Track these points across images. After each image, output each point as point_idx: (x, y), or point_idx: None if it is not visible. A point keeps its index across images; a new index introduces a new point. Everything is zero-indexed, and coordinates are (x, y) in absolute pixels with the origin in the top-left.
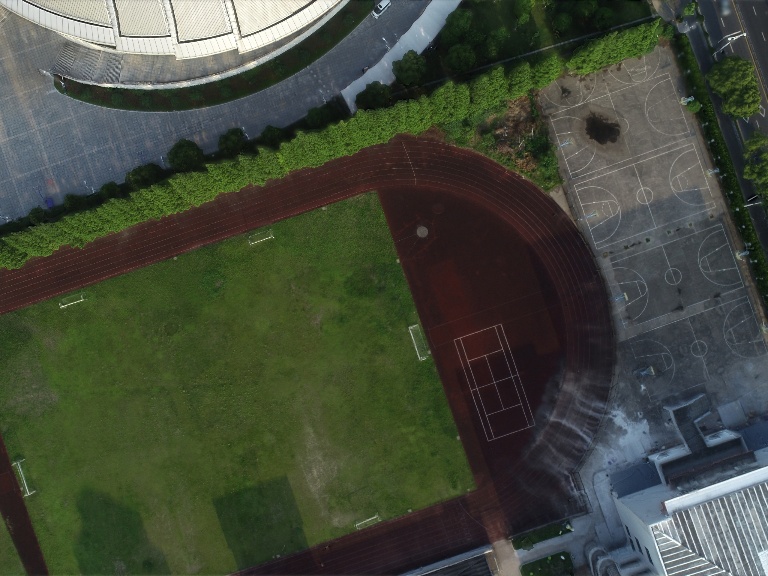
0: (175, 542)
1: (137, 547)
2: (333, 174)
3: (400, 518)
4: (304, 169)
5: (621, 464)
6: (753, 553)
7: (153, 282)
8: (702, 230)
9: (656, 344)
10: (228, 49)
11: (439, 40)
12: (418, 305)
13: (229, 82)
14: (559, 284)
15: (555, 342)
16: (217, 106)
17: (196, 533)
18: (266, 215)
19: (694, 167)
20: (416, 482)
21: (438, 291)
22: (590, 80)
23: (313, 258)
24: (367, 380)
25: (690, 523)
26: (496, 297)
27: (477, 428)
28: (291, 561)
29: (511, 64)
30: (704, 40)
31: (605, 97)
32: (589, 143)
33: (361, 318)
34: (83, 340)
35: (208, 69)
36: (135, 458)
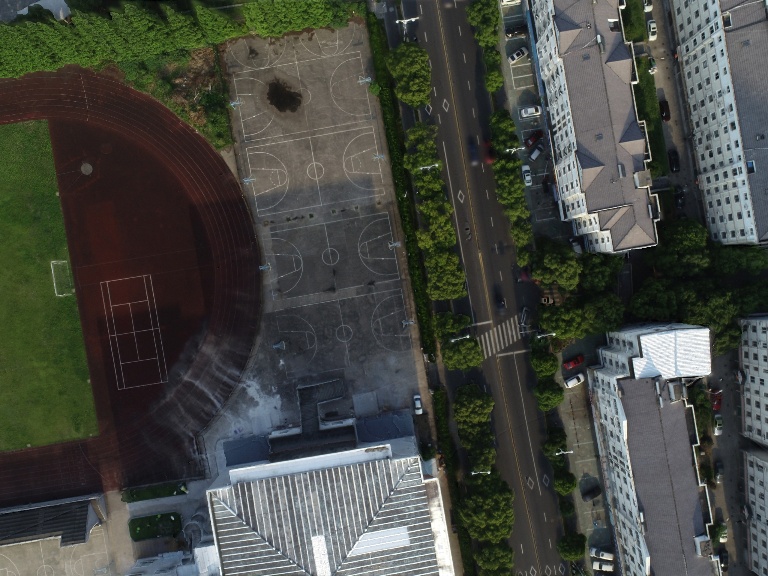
0: None
1: None
2: (6, 96)
3: (18, 451)
4: None
5: (246, 435)
6: (306, 536)
7: None
8: (367, 215)
9: (302, 321)
10: None
11: None
12: (70, 241)
13: None
14: (215, 245)
15: (201, 302)
16: None
17: None
18: None
19: (369, 150)
20: (39, 418)
21: (92, 231)
22: (280, 45)
23: None
24: (7, 308)
25: (250, 495)
26: (150, 247)
27: (109, 374)
28: None
29: (190, 13)
30: (398, 24)
31: (292, 65)
32: (268, 108)
33: (11, 245)
34: None
35: None
36: None
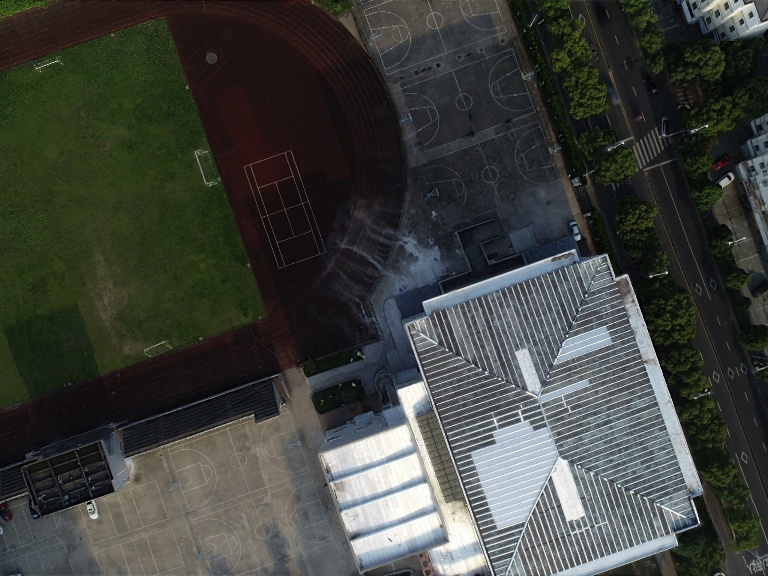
0: None
1: None
2: (121, 0)
3: (191, 346)
4: None
5: None
6: (510, 352)
7: None
8: (493, 55)
9: (447, 170)
10: None
11: None
12: (208, 132)
13: None
14: (349, 110)
15: (345, 168)
16: None
17: None
18: (55, 42)
19: None
20: (207, 310)
21: (227, 117)
22: None
23: (102, 85)
24: (157, 207)
25: (447, 322)
26: (286, 123)
27: (267, 255)
28: (83, 389)
29: None
30: None
31: None
32: None
33: (151, 145)
34: None
35: None
36: None
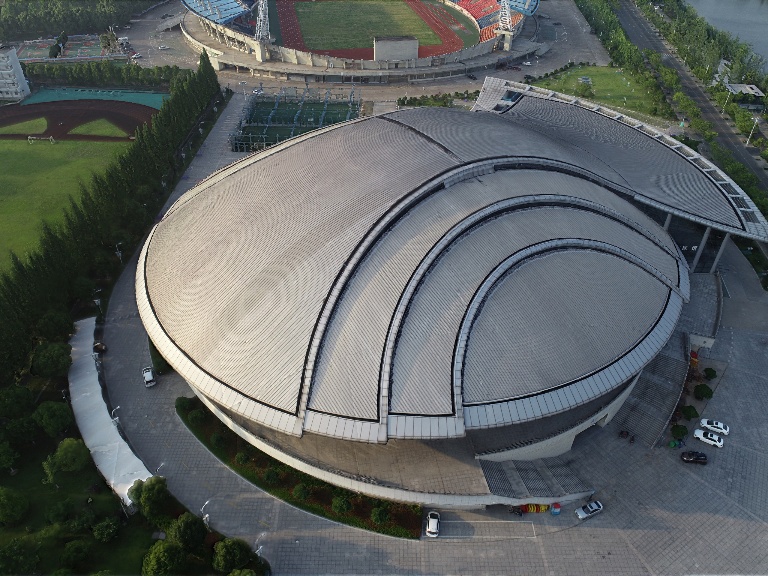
0: None
1: None
2: None
3: None
4: None
5: None
6: None
7: None
8: None
9: None
10: None
11: None
12: None
13: None
14: None
15: None
16: None
17: None
18: None
19: None
20: None
21: None
22: None
23: None
24: None
25: None
26: None
27: None
28: None
29: None
30: None
31: None
32: None
33: None
34: (89, 174)
35: None
36: None
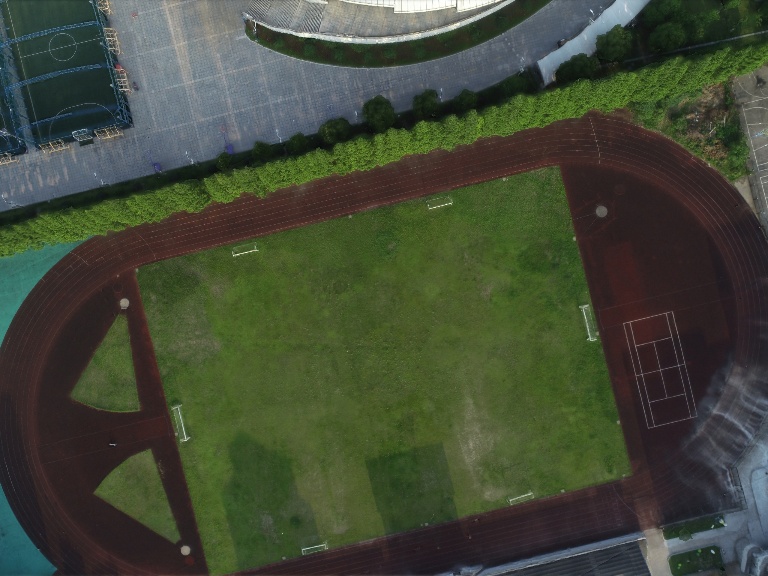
0: (325, 501)
1: (286, 502)
2: (517, 145)
3: (552, 497)
4: (488, 138)
5: None
6: None
7: (326, 238)
8: None
9: None
10: (447, 6)
11: (641, 18)
12: (590, 285)
13: (423, 43)
14: (735, 276)
15: (725, 335)
16: (407, 66)
17: (346, 494)
18: (445, 181)
19: None
20: (572, 463)
21: (612, 273)
22: None
23: (489, 228)
24: (532, 356)
25: None
26: (670, 284)
27: (638, 414)
28: (439, 530)
29: (714, 48)
30: None
31: None
32: None
33: (532, 293)
34: (250, 291)
35: (410, 27)
36: (292, 413)
